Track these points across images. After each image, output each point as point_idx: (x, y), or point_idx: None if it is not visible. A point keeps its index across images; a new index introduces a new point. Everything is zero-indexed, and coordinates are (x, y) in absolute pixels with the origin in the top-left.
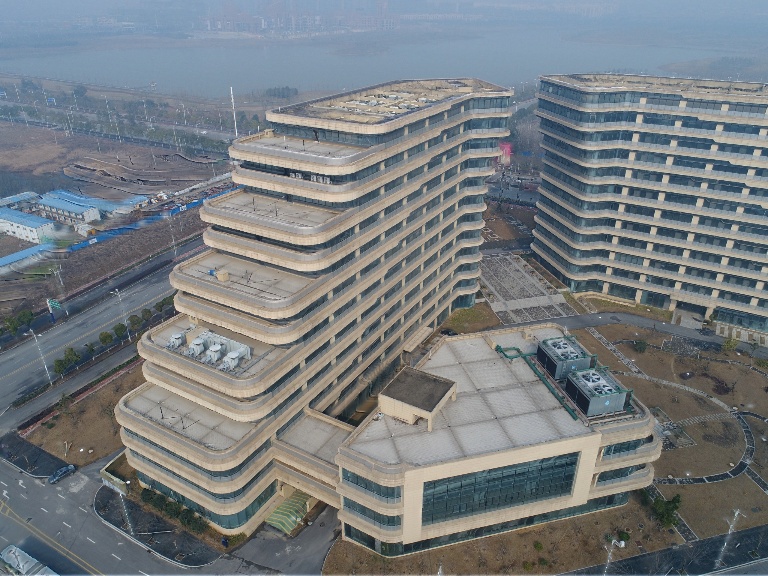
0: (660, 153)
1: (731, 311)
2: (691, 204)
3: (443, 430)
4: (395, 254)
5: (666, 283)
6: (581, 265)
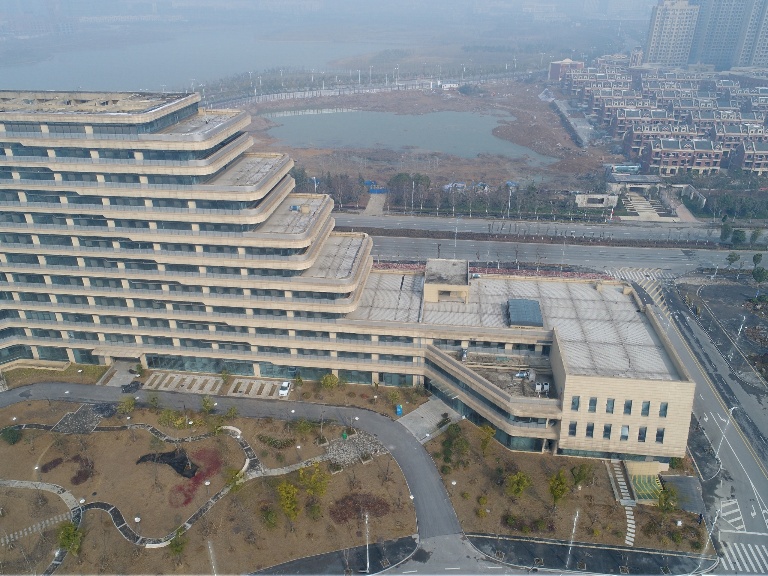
0: (6, 189)
1: (162, 355)
2: (68, 244)
3: None
4: None
5: (89, 336)
6: None
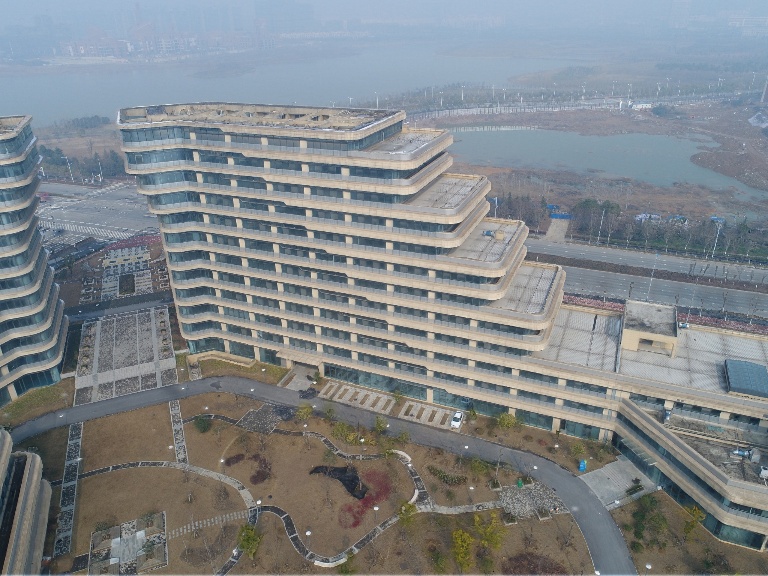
0: (224, 195)
1: (339, 366)
2: (269, 250)
3: None
4: None
5: (275, 338)
6: (189, 323)
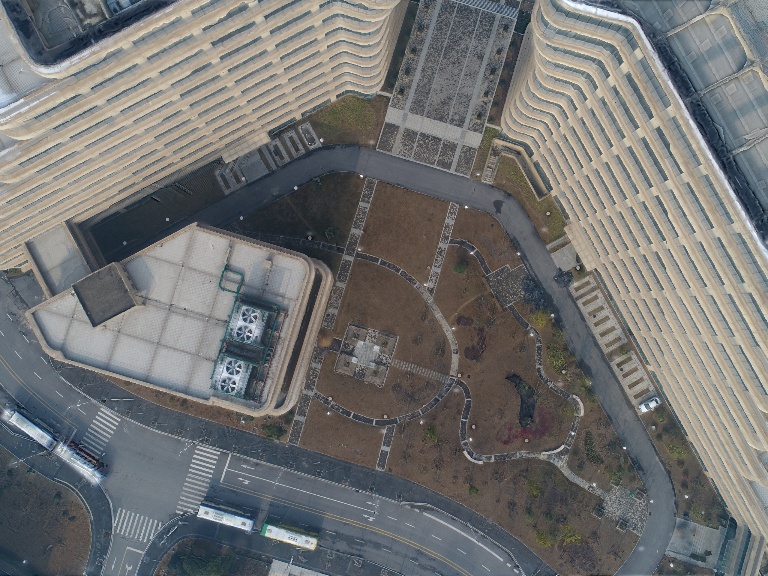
0: None
1: None
2: (623, 194)
3: (112, 332)
4: (167, 120)
5: None
6: None
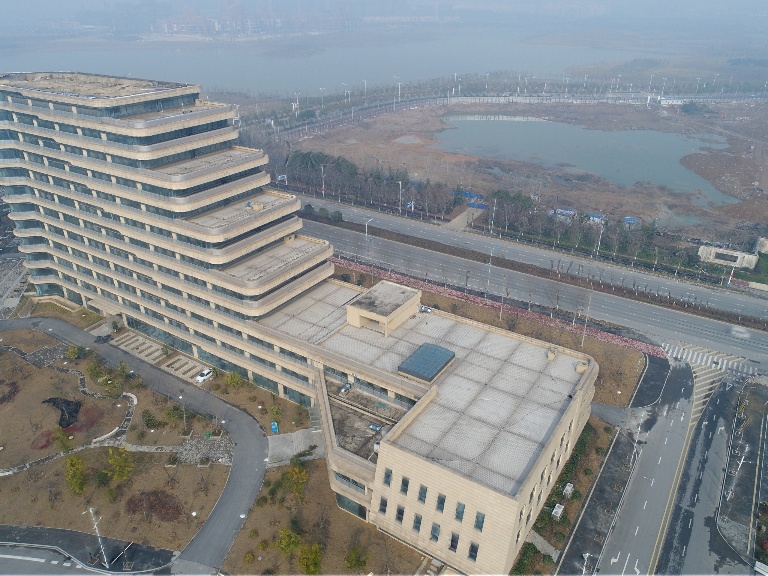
0: None
1: None
2: (73, 206)
3: None
4: None
5: (92, 288)
6: (31, 268)
